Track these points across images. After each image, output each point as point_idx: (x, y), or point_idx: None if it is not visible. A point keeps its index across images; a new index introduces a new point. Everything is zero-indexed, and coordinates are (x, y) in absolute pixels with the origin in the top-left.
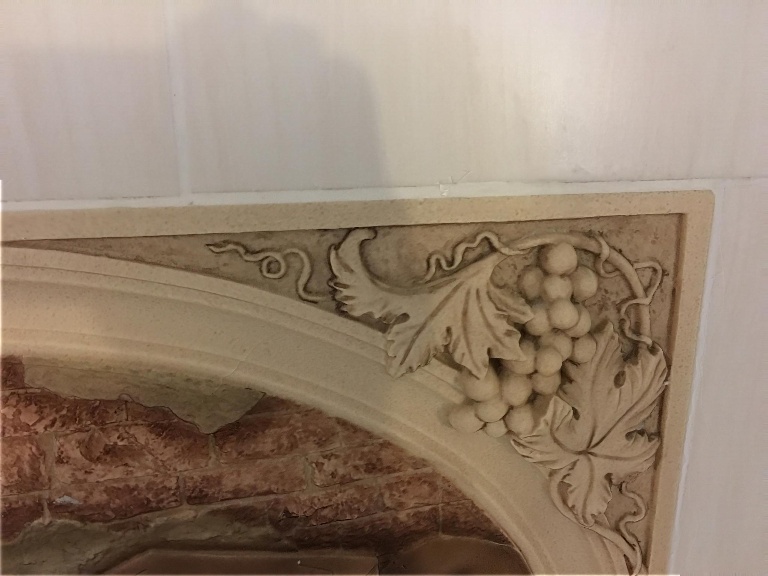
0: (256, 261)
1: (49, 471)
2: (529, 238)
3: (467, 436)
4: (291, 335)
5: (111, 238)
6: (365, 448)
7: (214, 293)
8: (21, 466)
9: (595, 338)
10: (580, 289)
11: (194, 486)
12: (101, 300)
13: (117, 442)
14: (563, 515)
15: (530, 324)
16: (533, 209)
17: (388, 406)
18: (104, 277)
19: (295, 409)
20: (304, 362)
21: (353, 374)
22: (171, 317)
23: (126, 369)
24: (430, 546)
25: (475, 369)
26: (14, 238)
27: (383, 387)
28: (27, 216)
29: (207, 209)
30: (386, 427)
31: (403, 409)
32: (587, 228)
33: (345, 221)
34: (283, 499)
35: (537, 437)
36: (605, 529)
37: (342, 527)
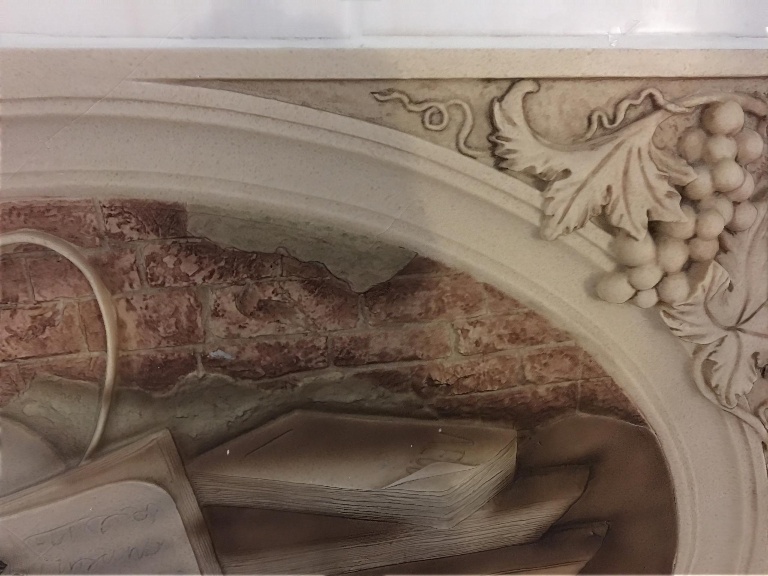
0: (419, 111)
1: (204, 324)
2: (695, 96)
3: (612, 310)
4: (447, 192)
5: (280, 81)
6: (510, 317)
7: (378, 142)
8: (179, 317)
9: (754, 206)
10: (746, 150)
11: (342, 347)
12: (264, 148)
13: (271, 297)
14: (703, 397)
15: (692, 186)
16: (702, 64)
17: (536, 273)
18: (272, 121)
19: (445, 272)
20: (457, 223)
21: (504, 238)
22: (330, 170)
23: (285, 221)
24: (567, 423)
25: (634, 230)
26: (189, 75)
27: (532, 253)
28: (203, 53)
29: (377, 52)
30: (533, 295)
31: (550, 278)
32: (752, 89)
33: (512, 70)
34: (427, 365)
35: (690, 306)
36: (746, 413)
37: (482, 399)
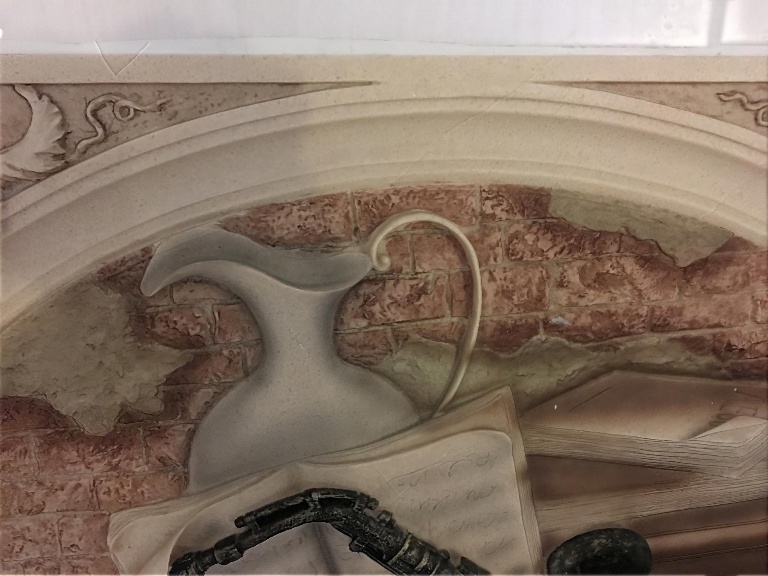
0: (755, 110)
1: None
2: None
3: None
4: (766, 180)
5: (646, 84)
6: None
7: (721, 136)
8: (530, 287)
9: None
10: None
11: (660, 315)
12: (621, 141)
13: (609, 270)
14: None
15: None
16: None
17: None
18: (636, 118)
19: (752, 250)
20: (767, 207)
21: None
22: (671, 160)
23: (631, 204)
24: None
25: None
26: (579, 79)
27: None
28: (593, 59)
29: (732, 59)
30: None
31: None
32: None
33: None
34: (728, 332)
35: None
36: None
37: None
